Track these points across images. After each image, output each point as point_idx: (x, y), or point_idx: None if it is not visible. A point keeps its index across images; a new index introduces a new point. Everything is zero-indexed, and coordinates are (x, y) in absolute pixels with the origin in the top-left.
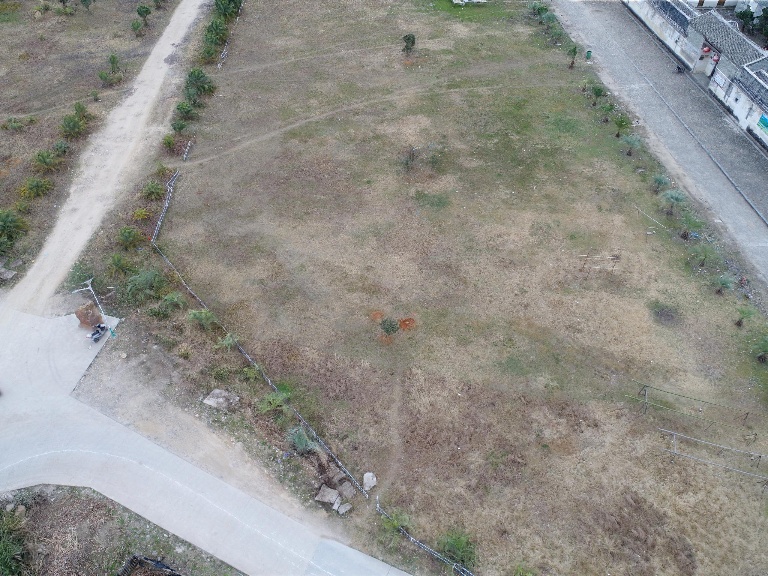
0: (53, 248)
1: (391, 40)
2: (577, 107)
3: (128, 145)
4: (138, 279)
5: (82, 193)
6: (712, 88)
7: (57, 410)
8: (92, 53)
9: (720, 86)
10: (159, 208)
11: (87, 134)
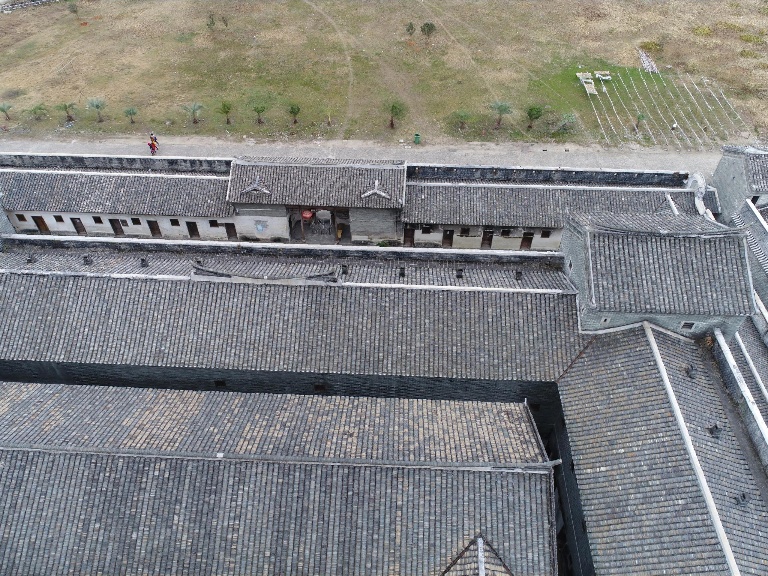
0: None
1: (466, 39)
2: None
3: None
4: None
5: None
6: None
7: None
8: None
9: None
10: None
11: None
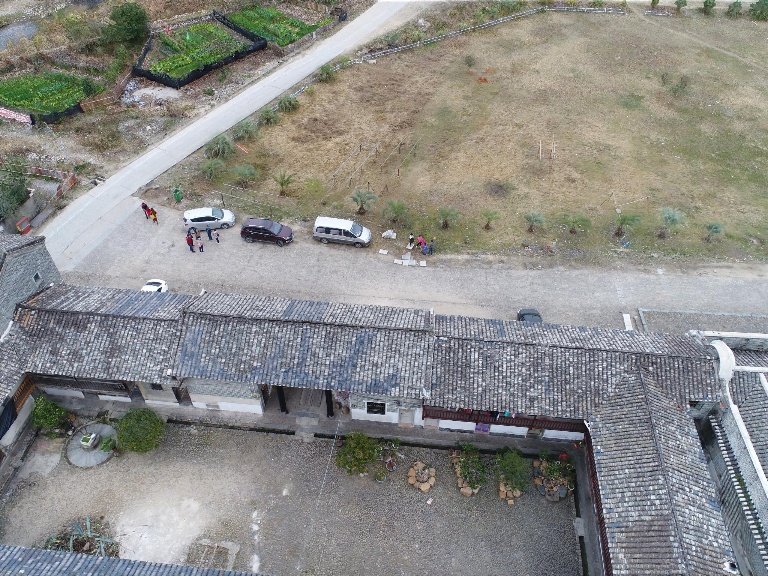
0: None
1: None
2: None
3: None
4: None
5: None
6: None
7: None
8: None
9: None
10: None
11: None
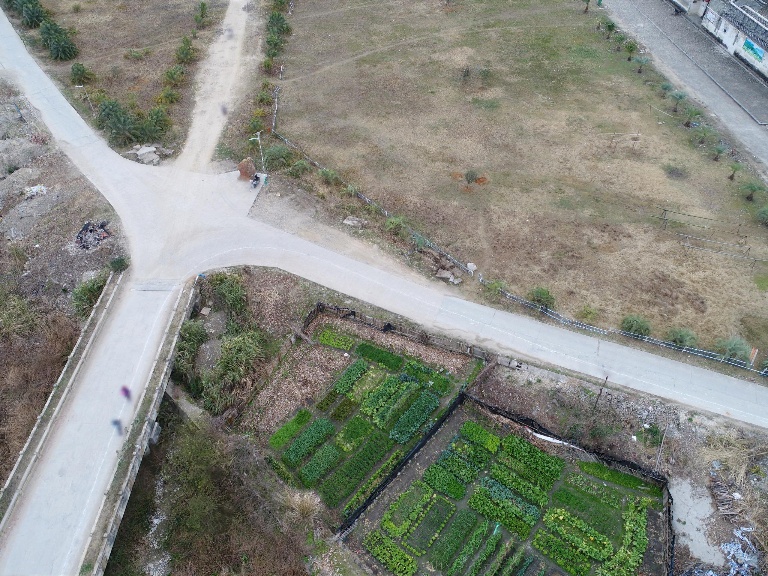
0: (196, 136)
1: None
2: (594, 40)
3: (232, 69)
4: (273, 151)
5: (206, 101)
6: (704, 24)
7: (240, 225)
8: (179, 4)
9: (711, 22)
10: (270, 110)
11: (196, 61)
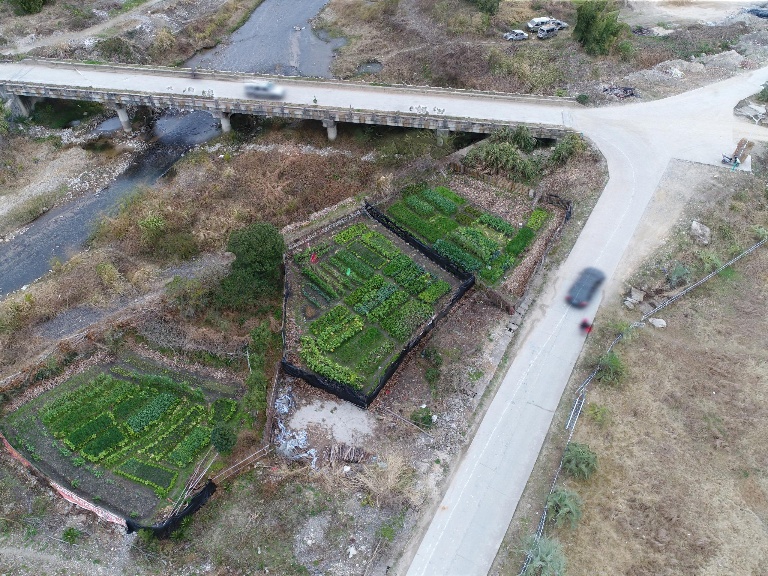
0: None
1: None
2: None
3: None
4: None
5: None
6: None
7: (658, 155)
8: None
9: None
10: None
11: None
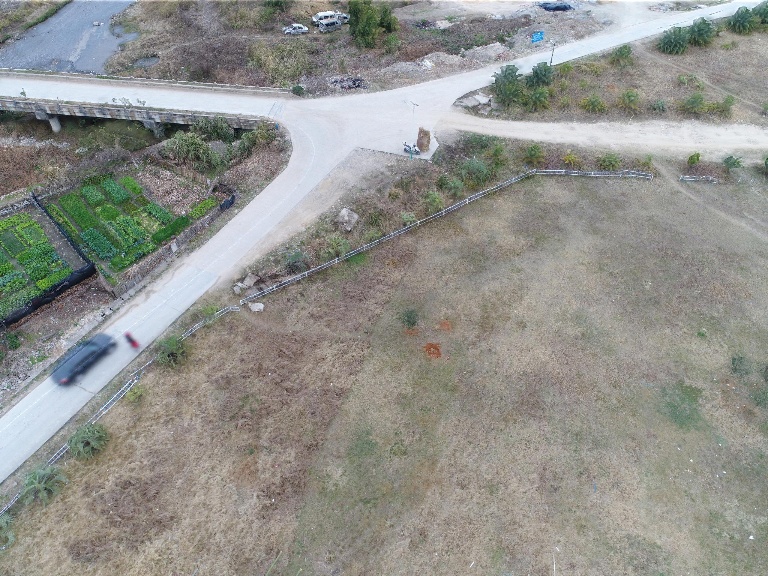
0: (518, 125)
1: None
2: None
3: (688, 142)
4: (475, 162)
5: (597, 129)
6: None
7: (345, 144)
8: None
9: None
10: None
11: (694, 117)
